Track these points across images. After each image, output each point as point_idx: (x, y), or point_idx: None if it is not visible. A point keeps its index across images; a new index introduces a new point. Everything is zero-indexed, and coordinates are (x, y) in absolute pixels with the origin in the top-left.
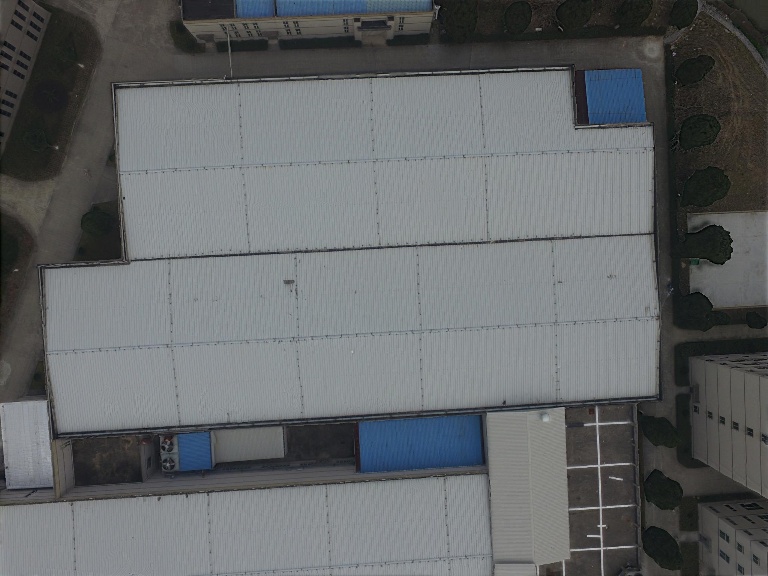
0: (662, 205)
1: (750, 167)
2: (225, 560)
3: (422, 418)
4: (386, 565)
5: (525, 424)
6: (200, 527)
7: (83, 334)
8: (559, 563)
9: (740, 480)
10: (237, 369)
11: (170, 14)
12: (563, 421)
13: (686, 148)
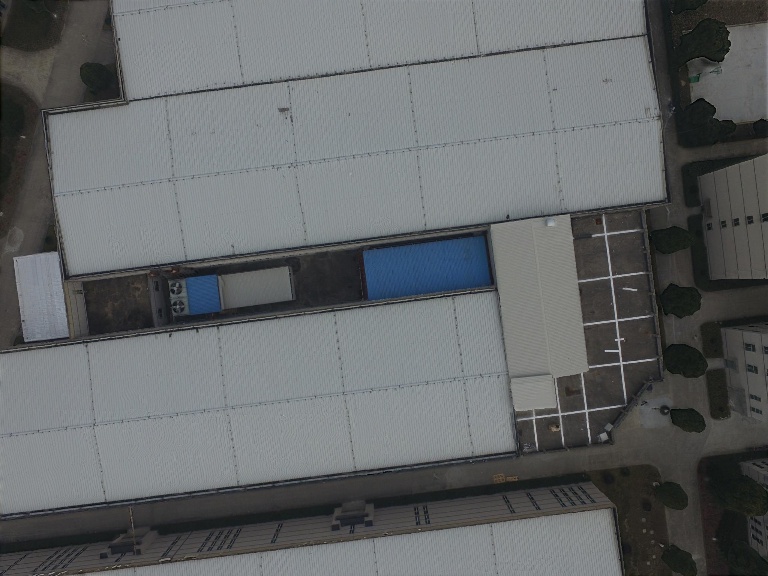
0: (656, 25)
1: None
2: (239, 392)
3: (426, 244)
4: (400, 388)
5: (530, 232)
6: (212, 361)
7: (88, 175)
8: (578, 381)
9: (760, 274)
10: (238, 199)
11: None
12: (569, 228)
13: None
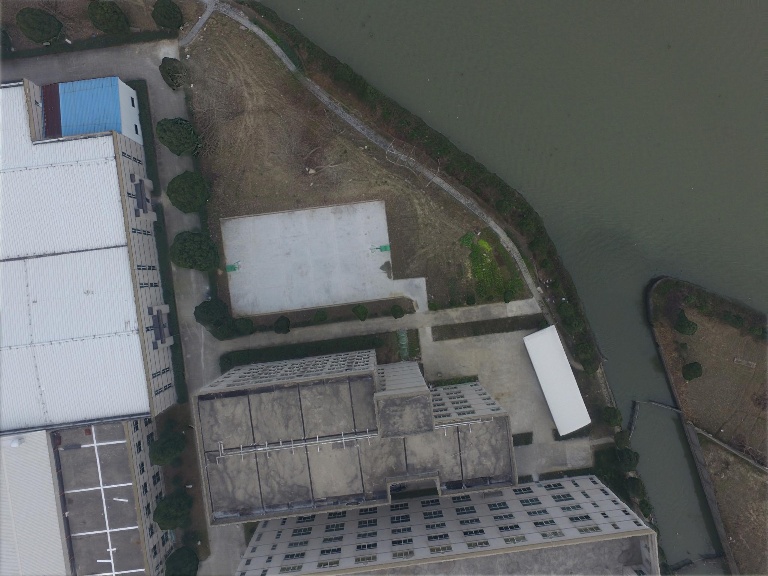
0: (193, 212)
1: (268, 166)
2: None
3: None
4: None
5: None
6: None
7: None
8: None
9: None
10: None
11: None
12: (45, 445)
13: (175, 153)
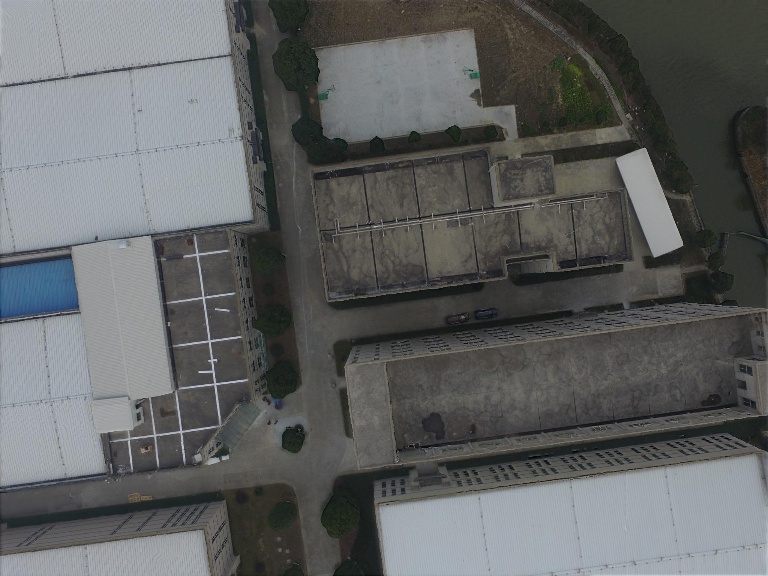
0: None
1: None
2: None
3: (28, 265)
4: None
5: (106, 253)
6: None
7: None
8: (173, 402)
9: None
10: None
11: None
12: (150, 250)
13: None
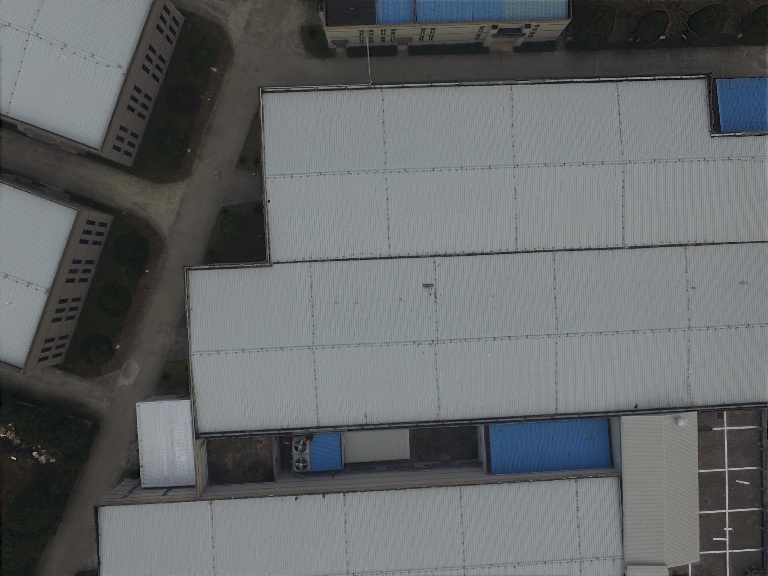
0: None
1: None
2: (361, 560)
3: None
4: (519, 566)
5: (660, 428)
6: (336, 527)
7: (226, 335)
8: (685, 565)
9: None
10: (376, 371)
11: (301, 19)
12: (696, 425)
13: None
